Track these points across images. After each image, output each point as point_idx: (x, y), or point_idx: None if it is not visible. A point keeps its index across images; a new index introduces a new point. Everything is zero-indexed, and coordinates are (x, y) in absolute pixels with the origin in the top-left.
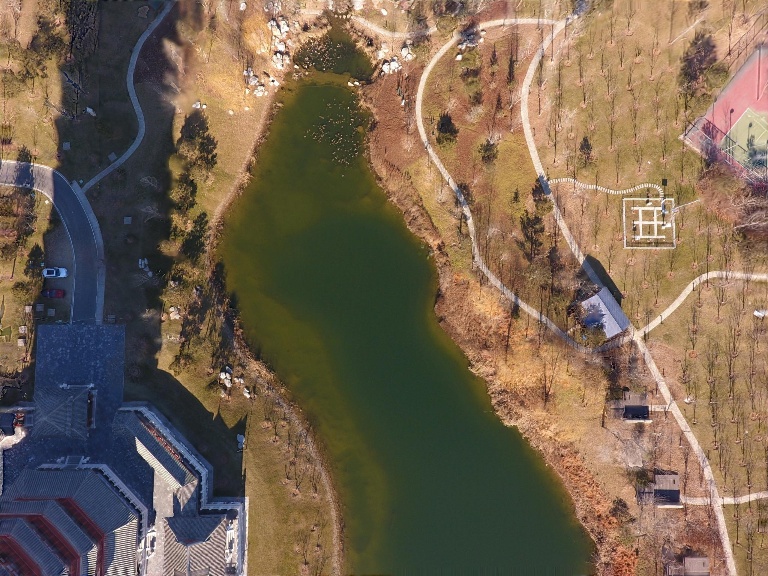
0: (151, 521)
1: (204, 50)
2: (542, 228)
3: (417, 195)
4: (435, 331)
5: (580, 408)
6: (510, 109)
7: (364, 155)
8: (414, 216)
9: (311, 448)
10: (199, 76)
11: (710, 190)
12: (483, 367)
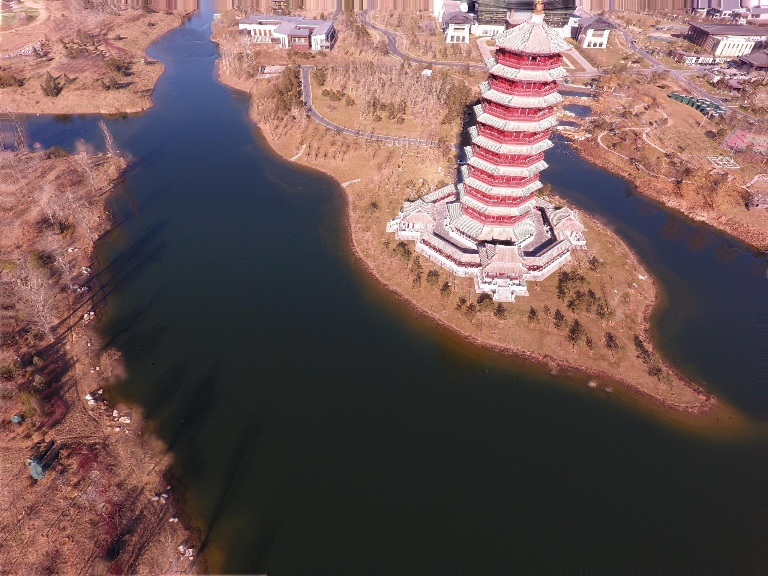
0: None
1: None
2: (676, 163)
3: (611, 162)
4: (641, 197)
5: (733, 208)
6: (642, 140)
7: (581, 156)
8: (612, 167)
9: (598, 222)
10: None
11: (743, 155)
12: (673, 202)
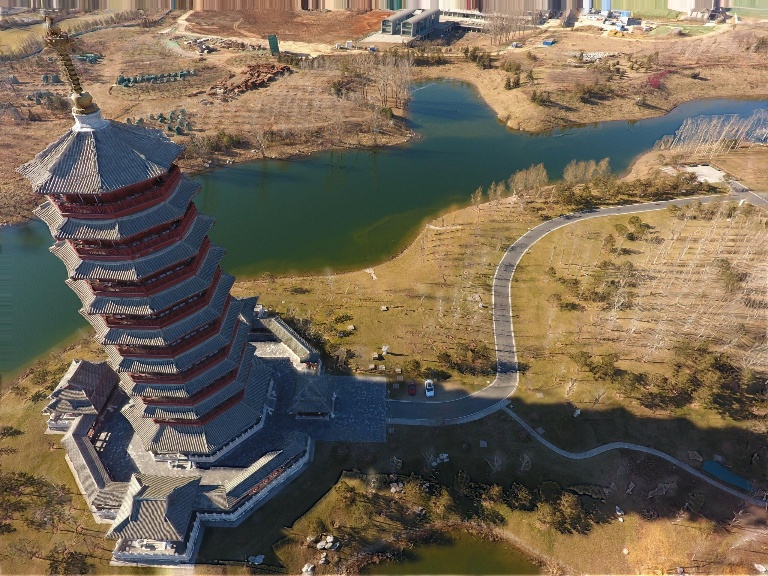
0: (201, 465)
1: (684, 519)
2: None
3: None
4: None
5: None
6: None
7: None
8: None
9: None
10: (653, 514)
11: None
12: None
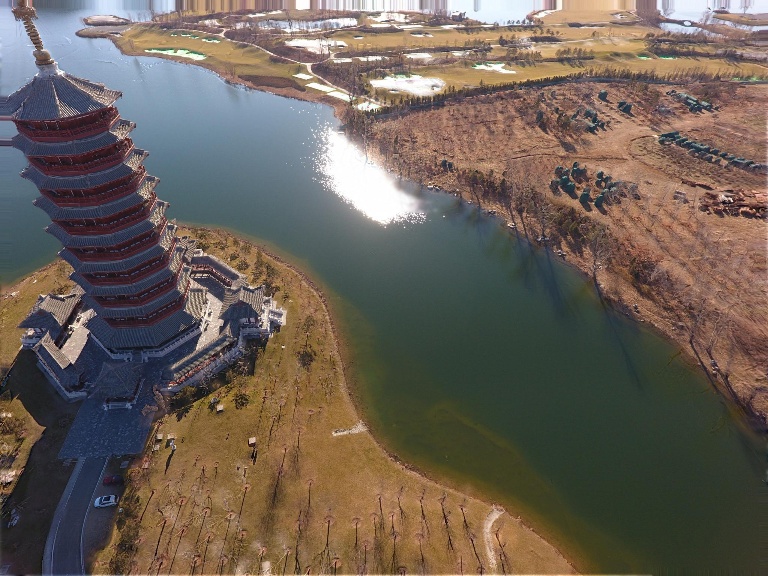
0: None
1: None
2: None
3: None
4: None
5: None
6: None
7: None
8: None
9: None
10: None
11: None
12: None
